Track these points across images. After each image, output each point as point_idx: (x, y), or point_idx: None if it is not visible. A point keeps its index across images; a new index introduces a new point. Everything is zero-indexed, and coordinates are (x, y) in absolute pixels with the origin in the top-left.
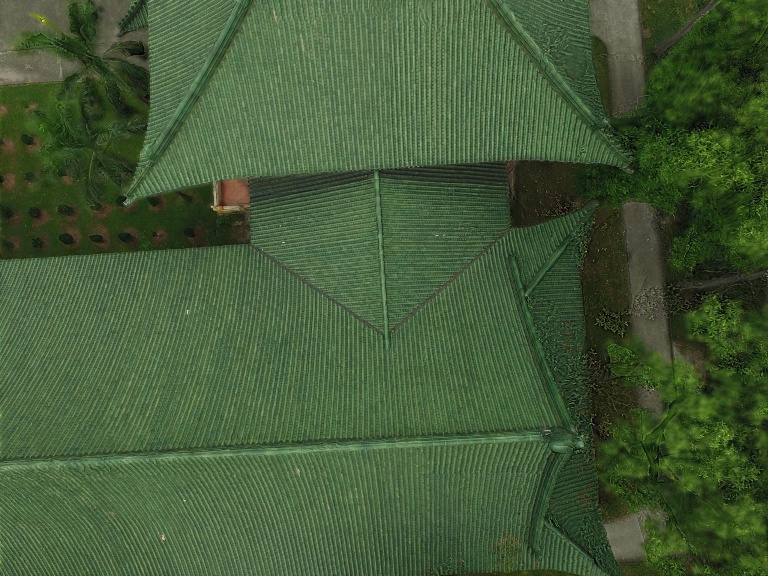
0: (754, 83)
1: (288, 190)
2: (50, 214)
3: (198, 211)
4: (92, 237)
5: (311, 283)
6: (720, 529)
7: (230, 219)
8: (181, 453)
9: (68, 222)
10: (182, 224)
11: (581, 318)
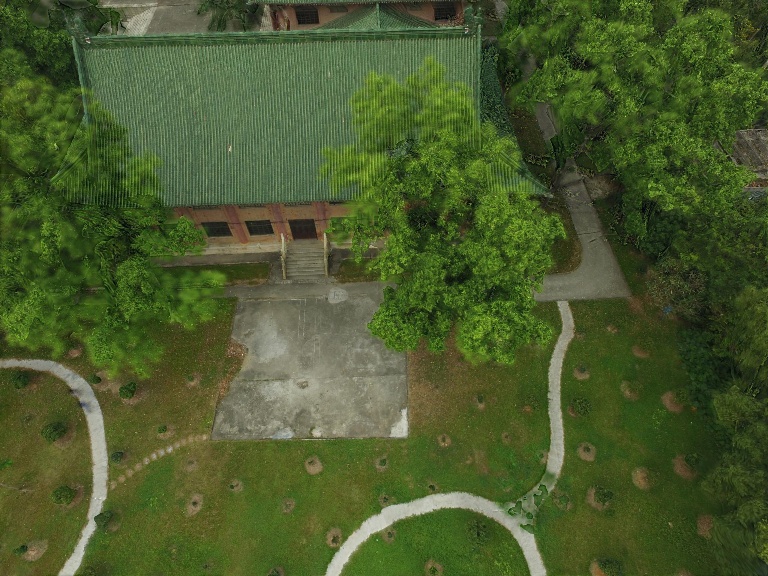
0: (580, 20)
1: None
2: None
3: None
4: None
5: None
6: (645, 271)
7: None
8: None
9: None
10: None
11: (499, 85)
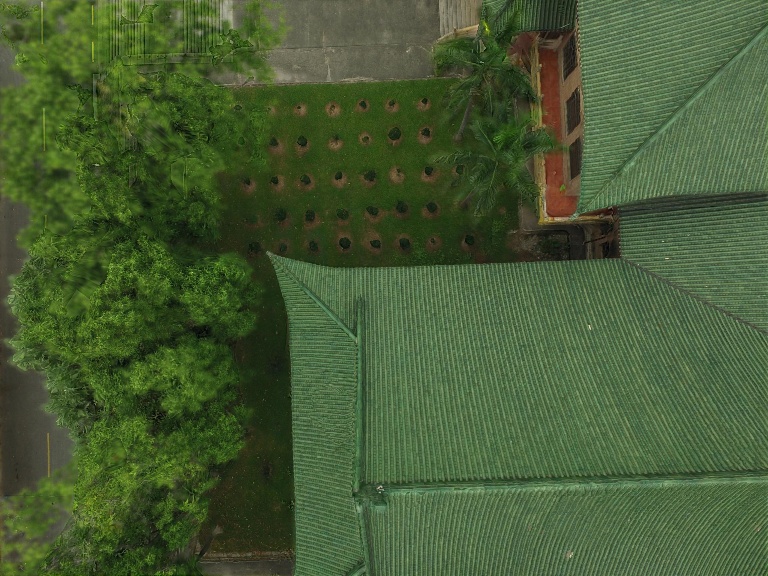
0: None
1: (674, 206)
2: (320, 217)
3: (473, 218)
4: (374, 242)
5: (708, 301)
6: None
7: (506, 227)
8: (722, 478)
9: (339, 226)
10: (456, 231)
11: None
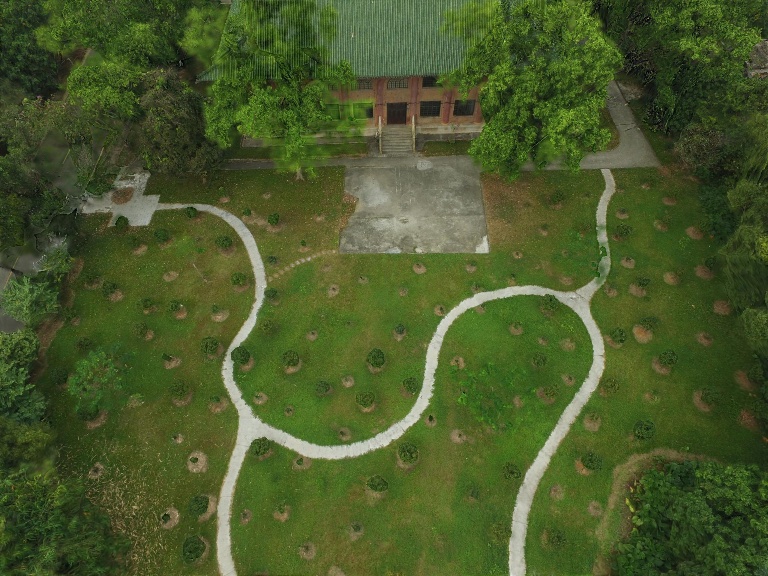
0: None
1: None
2: None
3: None
4: None
5: None
6: (672, 148)
7: None
8: None
9: None
10: None
11: None
